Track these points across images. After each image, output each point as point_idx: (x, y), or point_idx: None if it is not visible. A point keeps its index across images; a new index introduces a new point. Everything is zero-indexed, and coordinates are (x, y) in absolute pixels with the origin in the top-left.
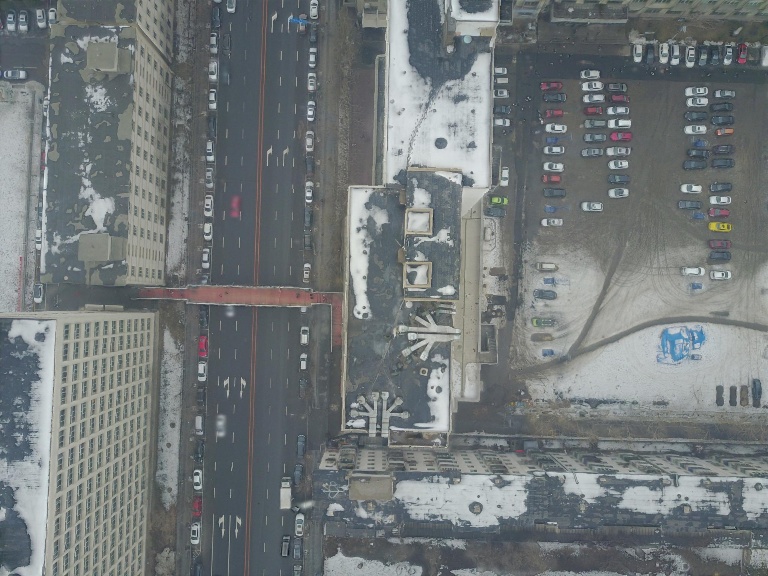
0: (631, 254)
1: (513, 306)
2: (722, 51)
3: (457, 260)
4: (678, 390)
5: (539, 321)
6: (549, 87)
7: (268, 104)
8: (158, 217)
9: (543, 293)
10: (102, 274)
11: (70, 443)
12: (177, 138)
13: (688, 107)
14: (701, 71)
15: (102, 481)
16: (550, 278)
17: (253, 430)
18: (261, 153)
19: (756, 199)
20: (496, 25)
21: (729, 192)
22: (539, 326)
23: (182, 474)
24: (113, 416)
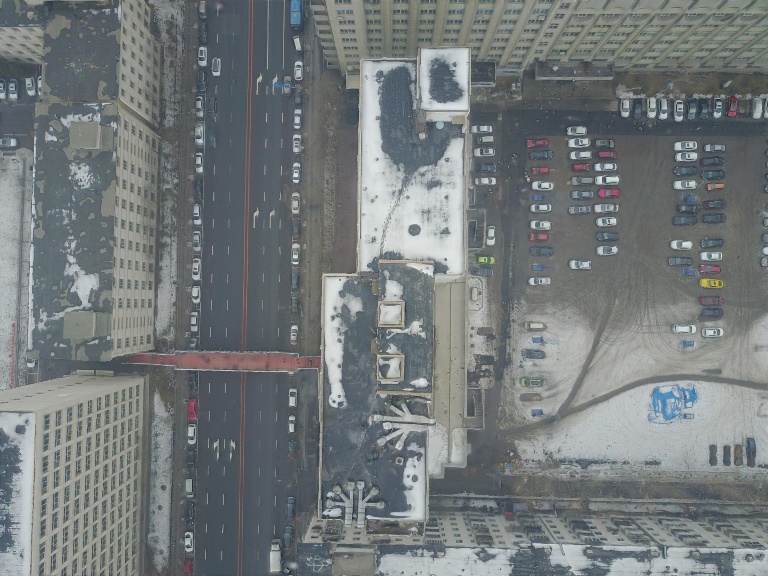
0: (621, 312)
1: (501, 366)
2: (711, 104)
3: (430, 352)
4: (670, 450)
5: (528, 381)
6: (535, 144)
7: (254, 166)
8: (146, 283)
9: (531, 353)
10: (88, 350)
11: (53, 530)
12: (165, 202)
13: (677, 162)
14: (690, 125)
15: (89, 558)
16: (538, 337)
17: (243, 492)
18: (248, 215)
19: (748, 254)
20: (466, 114)
21: (720, 248)
22: (528, 386)
23: (174, 536)
24: (100, 491)
